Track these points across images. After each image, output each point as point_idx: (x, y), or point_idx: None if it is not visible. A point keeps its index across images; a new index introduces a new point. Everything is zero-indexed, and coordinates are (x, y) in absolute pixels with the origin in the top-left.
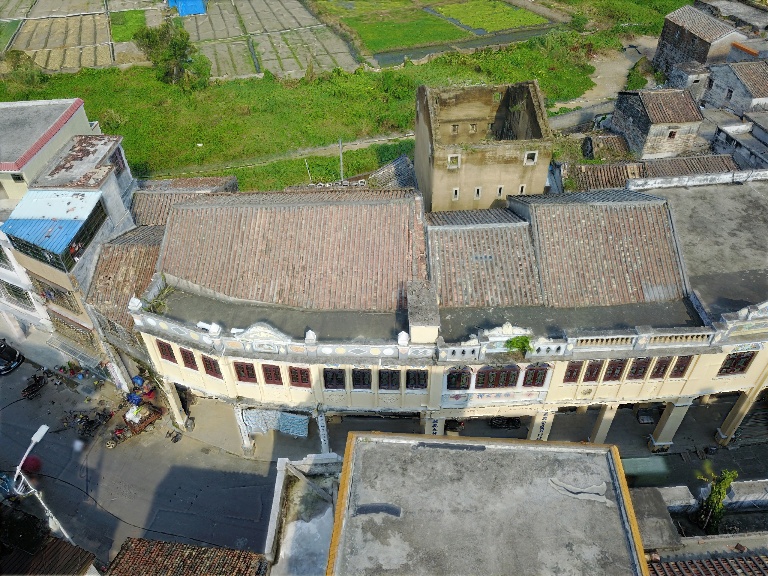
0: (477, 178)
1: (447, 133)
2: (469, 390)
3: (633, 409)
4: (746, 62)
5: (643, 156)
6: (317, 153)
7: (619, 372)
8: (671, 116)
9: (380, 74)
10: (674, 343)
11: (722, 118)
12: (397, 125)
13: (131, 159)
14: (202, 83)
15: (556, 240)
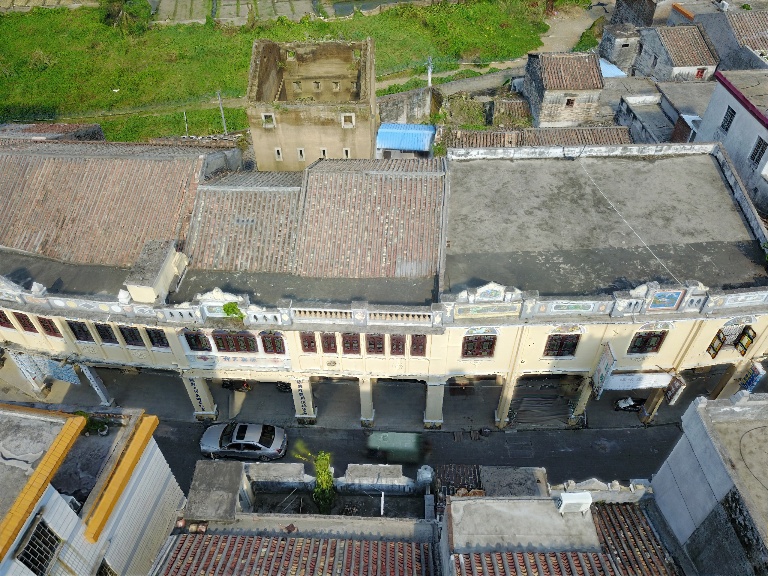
0: (297, 139)
1: (310, 90)
2: (212, 352)
3: (425, 384)
4: (681, 26)
5: (540, 124)
6: (227, 104)
7: (358, 346)
8: (568, 82)
9: None
10: (396, 321)
11: (642, 87)
12: None
13: (44, 102)
14: (140, 27)
15: (322, 207)
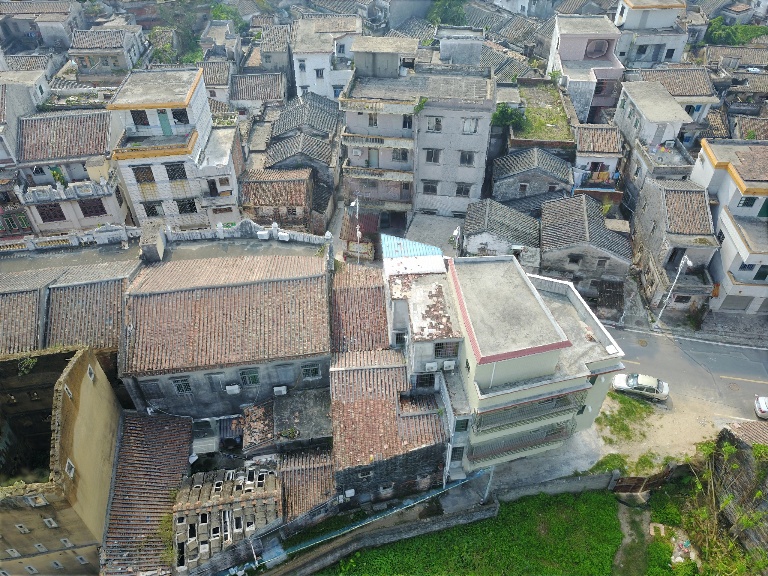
0: None
1: None
2: None
3: None
4: None
5: None
6: None
7: None
8: None
9: None
10: None
11: None
12: None
13: None
14: None
15: None
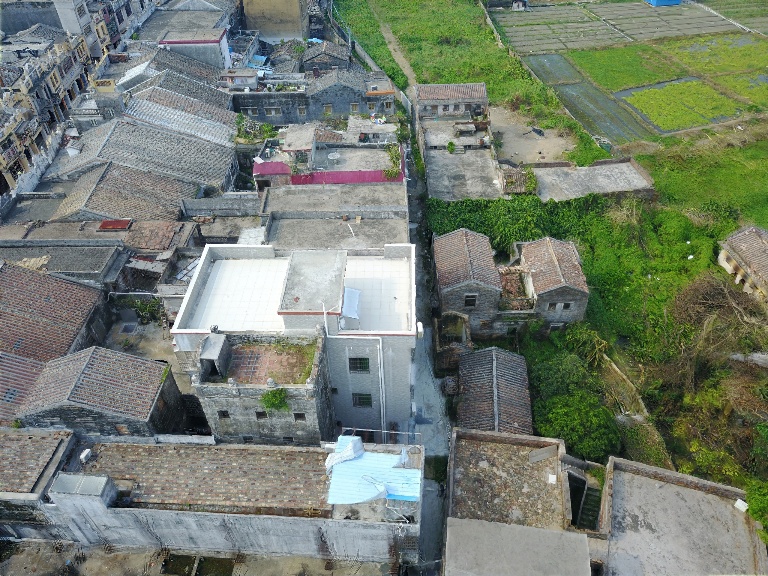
0: None
1: None
2: None
3: None
4: None
5: None
6: None
7: None
8: None
9: None
10: None
11: None
12: None
13: None
14: None
15: None
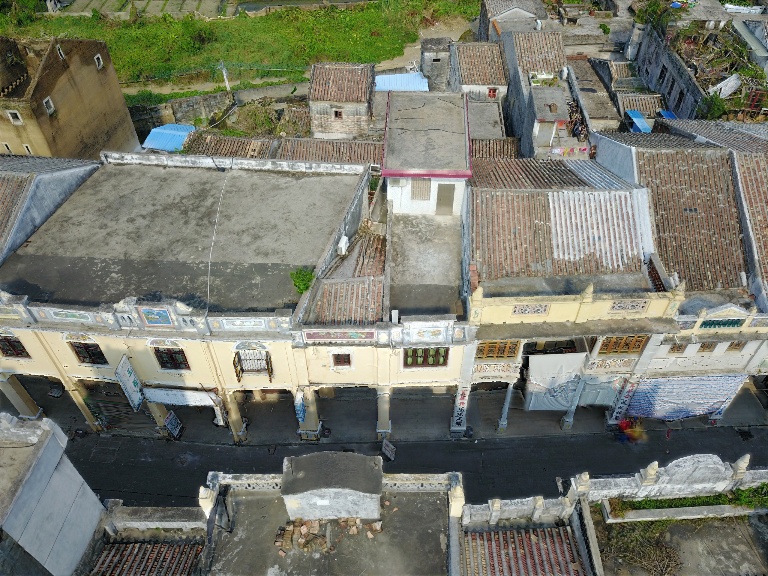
0: None
1: None
2: None
3: None
4: None
5: (315, 134)
6: None
7: None
8: (332, 94)
9: (204, 23)
10: None
11: None
12: (153, 76)
13: None
14: (26, 17)
15: None
